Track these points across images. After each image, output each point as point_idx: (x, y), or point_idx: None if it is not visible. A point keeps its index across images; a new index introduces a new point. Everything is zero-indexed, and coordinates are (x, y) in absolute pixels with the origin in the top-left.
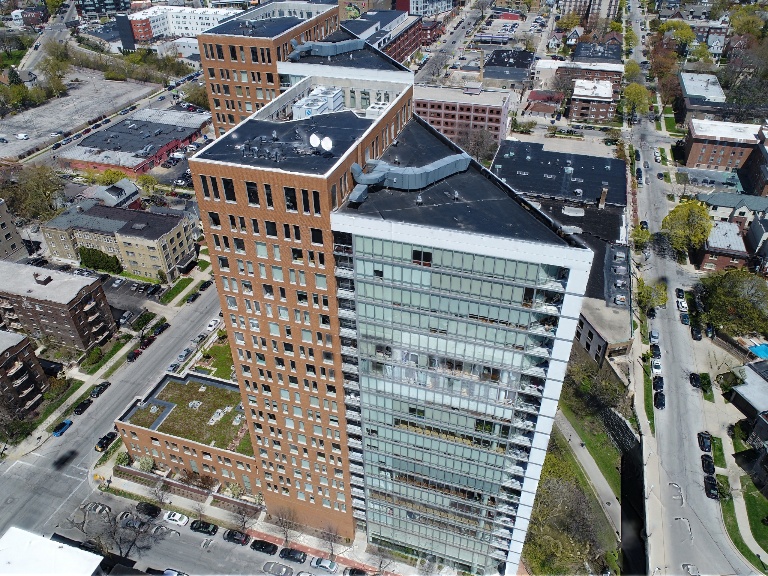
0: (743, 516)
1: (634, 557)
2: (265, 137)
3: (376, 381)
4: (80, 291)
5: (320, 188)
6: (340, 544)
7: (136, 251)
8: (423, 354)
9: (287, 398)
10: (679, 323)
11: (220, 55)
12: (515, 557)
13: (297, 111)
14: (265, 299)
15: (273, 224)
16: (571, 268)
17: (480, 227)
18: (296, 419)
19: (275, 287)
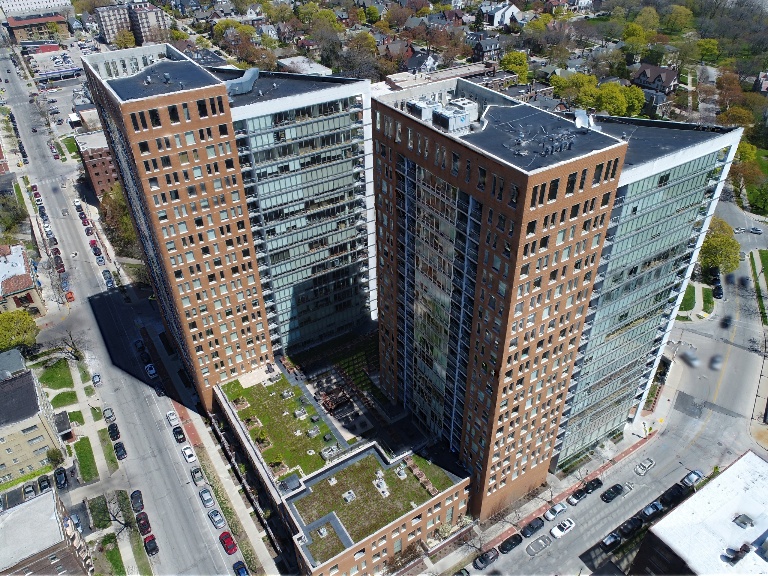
0: None
1: None
2: None
3: (605, 309)
4: (57, 515)
5: (622, 153)
6: (543, 492)
7: (1, 449)
8: (641, 262)
9: (534, 378)
10: None
11: (153, 122)
12: (646, 393)
13: (453, 122)
14: (549, 286)
15: (578, 206)
16: (732, 144)
17: (672, 144)
18: (537, 394)
19: (561, 268)
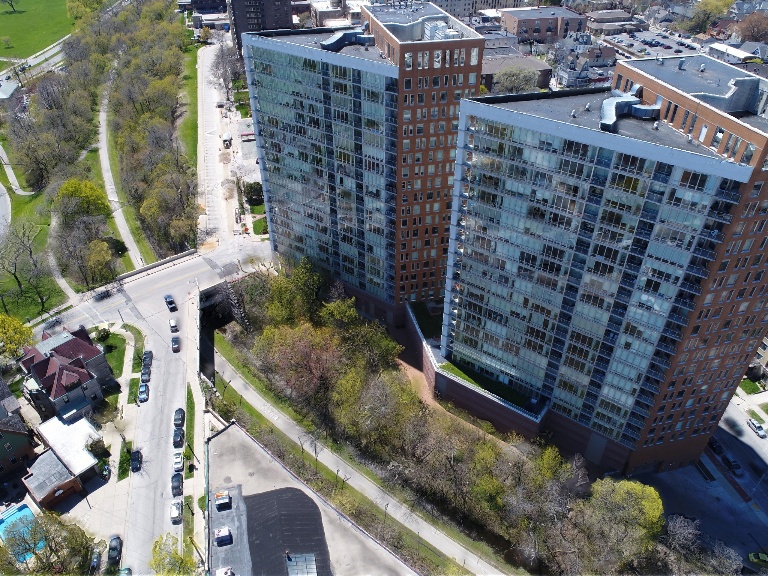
0: (129, 350)
1: (205, 343)
2: (416, 7)
3: None
4: None
5: None
6: None
7: None
8: None
9: None
10: (136, 568)
11: None
12: None
13: None
14: None
15: None
16: None
17: None
18: None
19: None
